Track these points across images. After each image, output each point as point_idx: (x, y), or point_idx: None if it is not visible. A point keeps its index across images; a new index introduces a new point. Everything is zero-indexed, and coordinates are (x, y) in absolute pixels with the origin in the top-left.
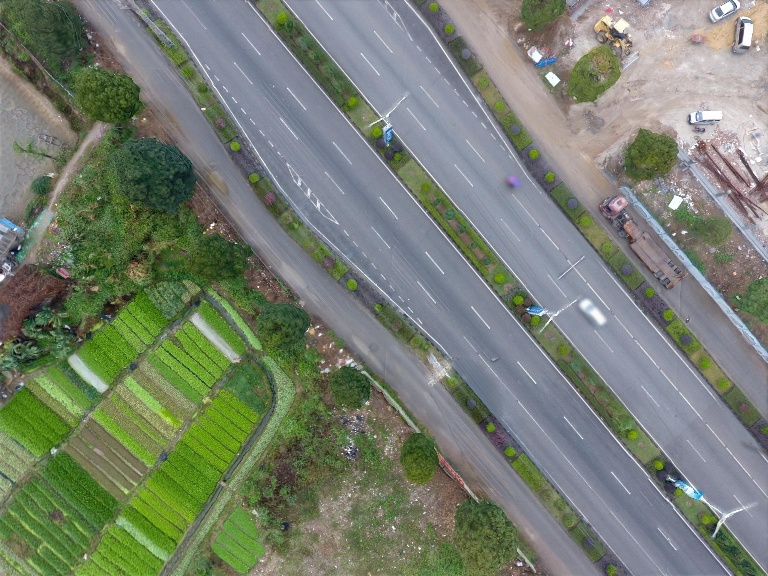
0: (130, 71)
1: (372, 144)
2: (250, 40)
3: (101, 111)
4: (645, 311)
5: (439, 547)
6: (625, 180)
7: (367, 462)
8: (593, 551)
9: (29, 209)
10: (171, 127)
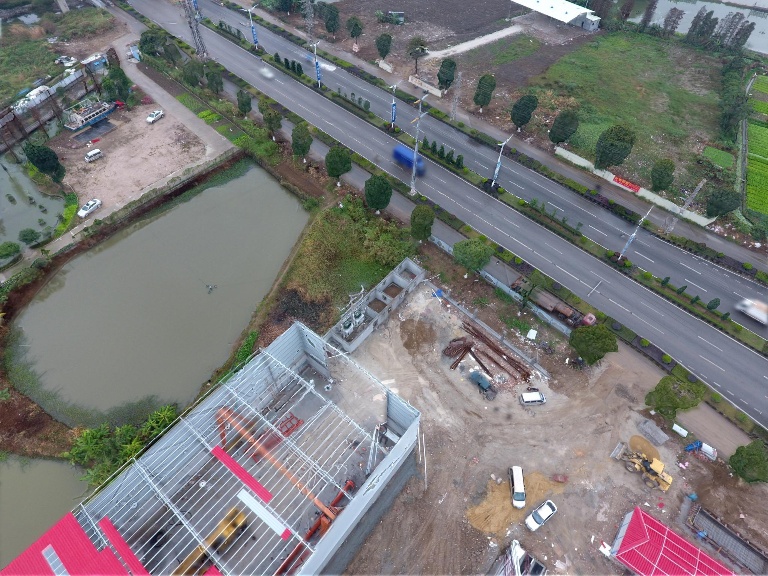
0: None
1: None
2: None
3: None
4: None
5: None
6: None
7: None
8: (525, 158)
9: None
10: None
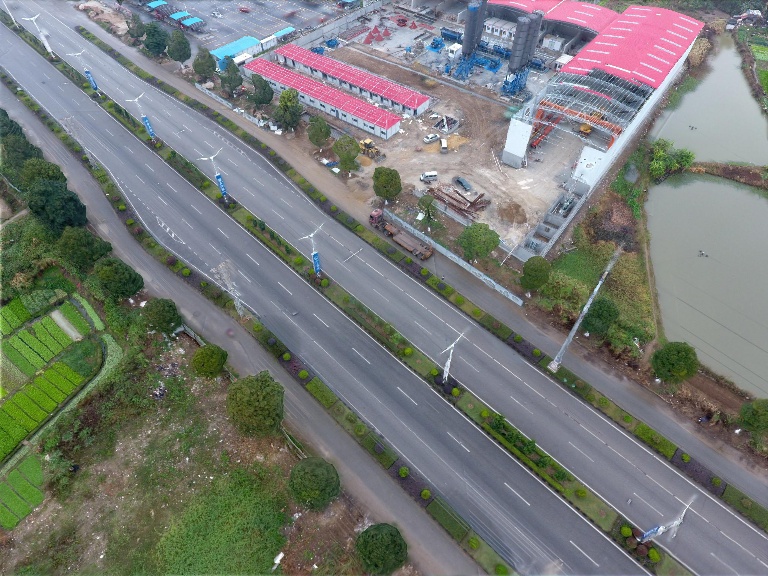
0: None
1: (217, 203)
2: (150, 166)
3: (34, 175)
4: (410, 275)
5: (231, 472)
6: None
7: (173, 400)
8: (385, 457)
9: None
10: None
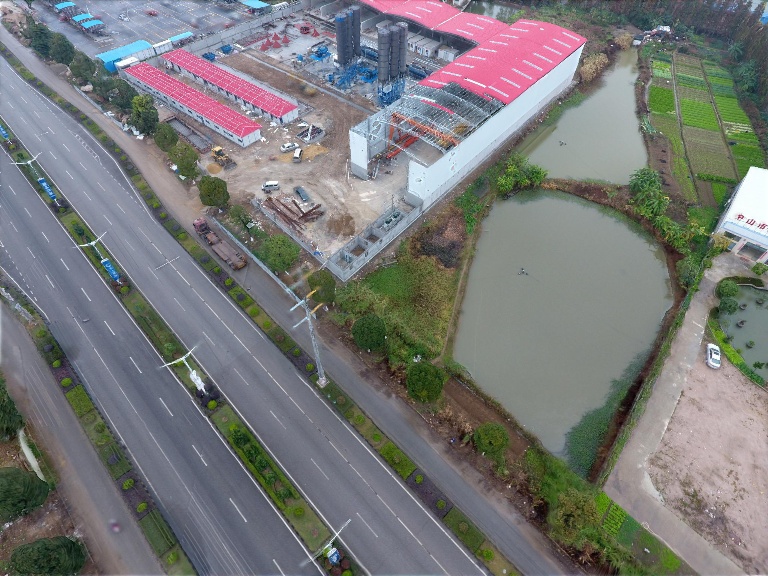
0: None
1: (50, 206)
2: None
3: None
4: (217, 285)
5: None
6: (218, 218)
7: None
8: (117, 468)
9: None
10: None
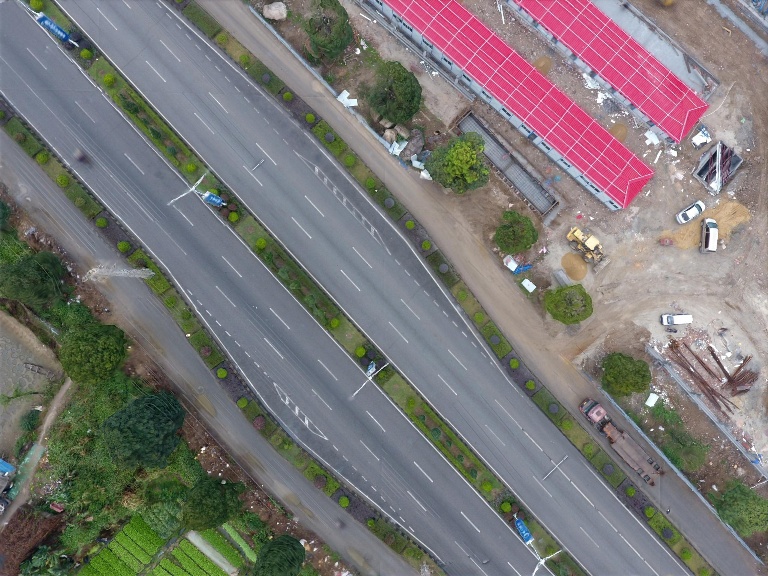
0: (112, 300)
1: (356, 361)
2: (231, 263)
3: (87, 378)
4: (627, 505)
5: None
6: None
7: None
8: None
9: (19, 446)
10: (157, 353)
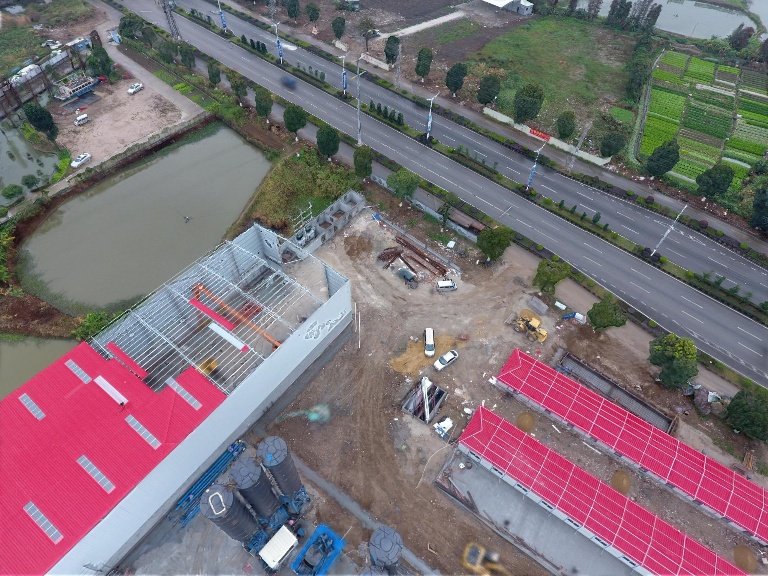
0: None
1: None
2: None
3: None
4: None
5: None
6: None
7: None
8: None
9: None
10: None
